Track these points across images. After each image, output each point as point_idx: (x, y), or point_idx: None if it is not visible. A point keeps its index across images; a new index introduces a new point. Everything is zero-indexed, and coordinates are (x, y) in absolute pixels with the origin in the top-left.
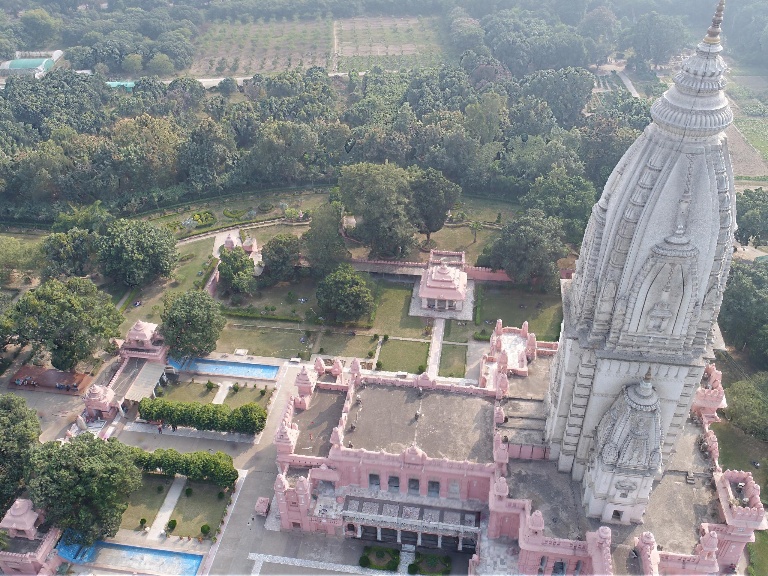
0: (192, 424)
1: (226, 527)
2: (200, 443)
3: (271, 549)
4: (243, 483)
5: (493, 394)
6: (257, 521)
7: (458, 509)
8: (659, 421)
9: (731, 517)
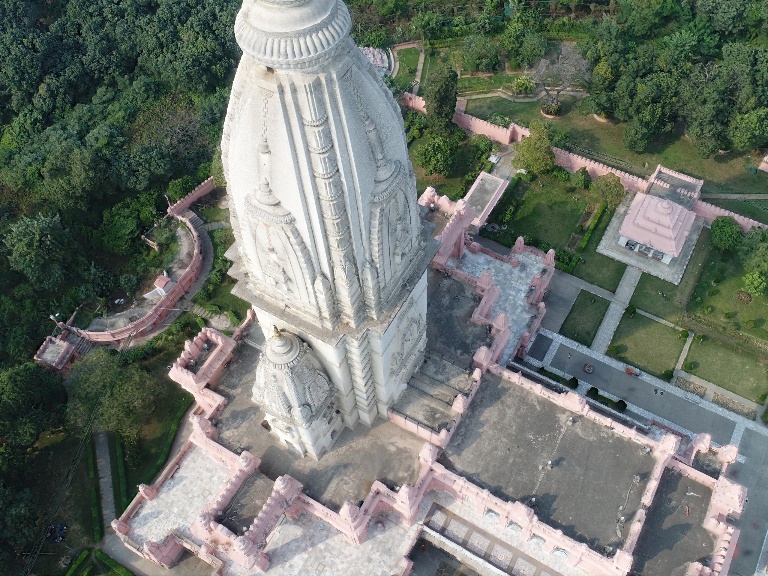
0: None
1: None
2: None
3: None
4: (759, 563)
5: None
6: None
7: None
8: None
9: None
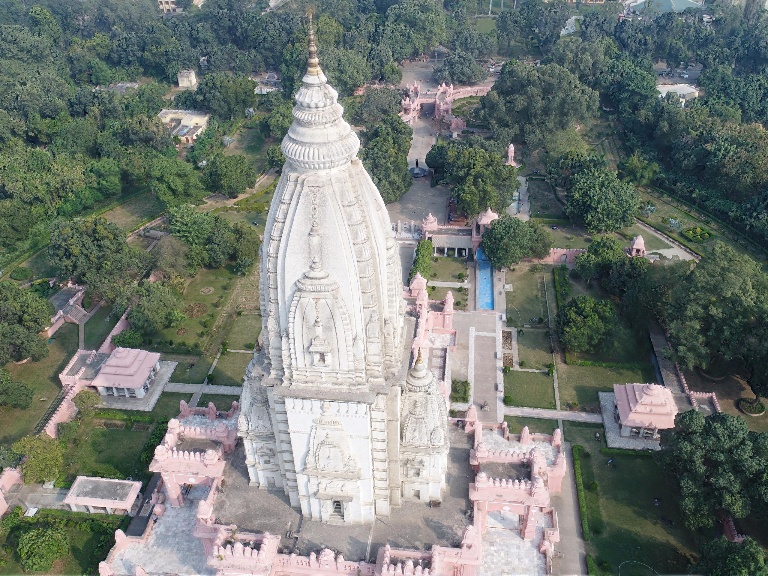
0: None
1: None
2: (404, 282)
3: None
4: None
5: None
6: None
7: None
8: (245, 387)
9: None
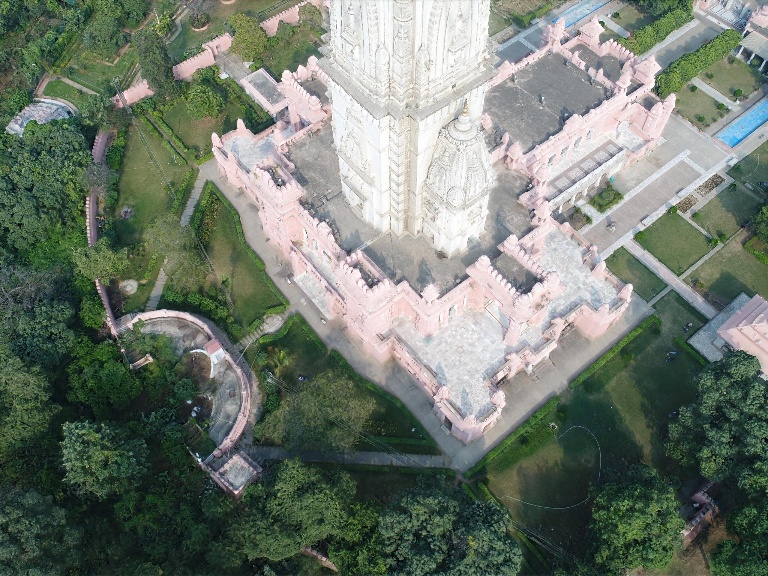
0: None
1: None
2: None
3: None
4: None
5: None
6: None
7: None
8: None
9: (275, 162)
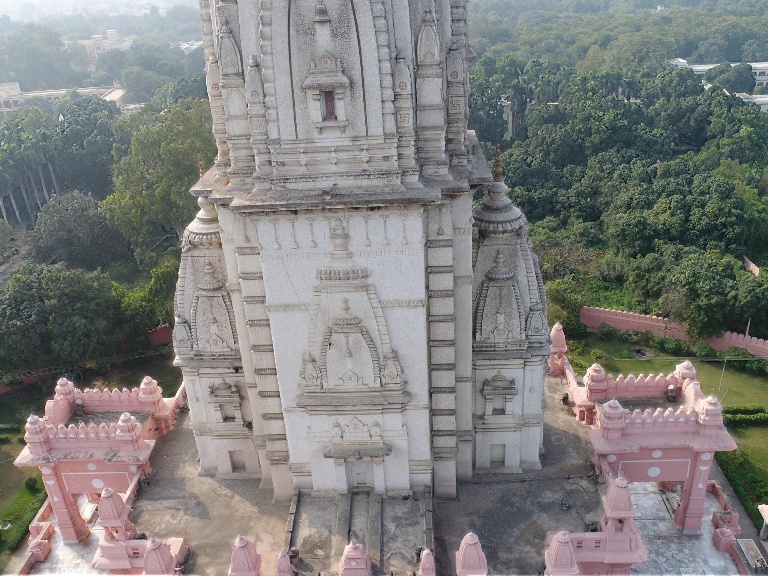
0: None
1: None
2: None
3: None
4: None
5: None
6: None
7: None
8: None
9: None
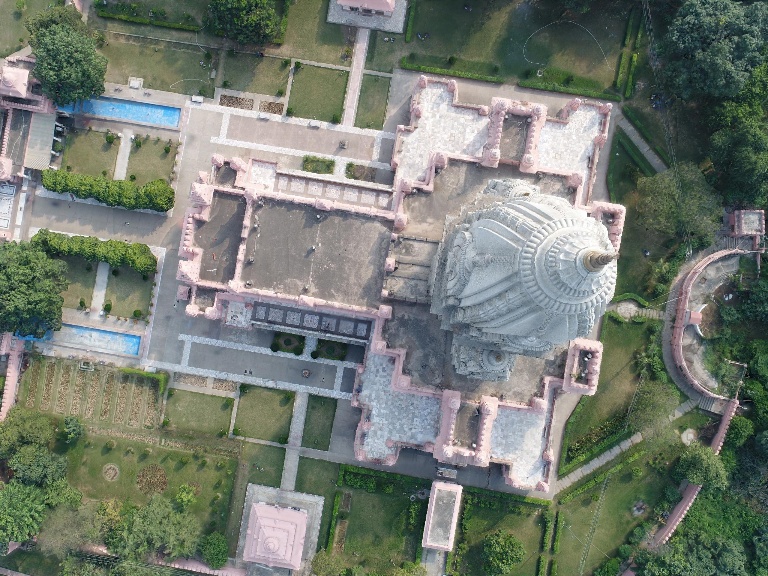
0: (101, 202)
1: (155, 308)
2: (115, 215)
3: (197, 331)
4: (164, 262)
5: (392, 220)
6: (182, 303)
7: (353, 318)
8: None
9: (567, 385)
